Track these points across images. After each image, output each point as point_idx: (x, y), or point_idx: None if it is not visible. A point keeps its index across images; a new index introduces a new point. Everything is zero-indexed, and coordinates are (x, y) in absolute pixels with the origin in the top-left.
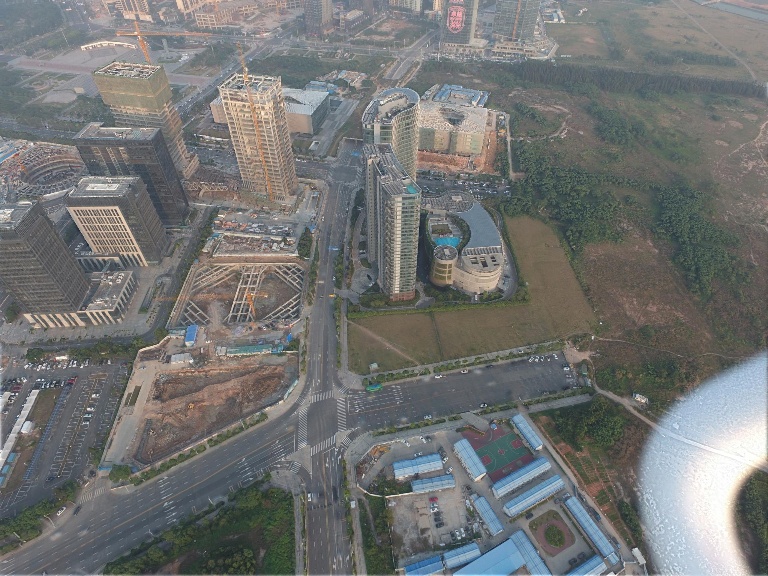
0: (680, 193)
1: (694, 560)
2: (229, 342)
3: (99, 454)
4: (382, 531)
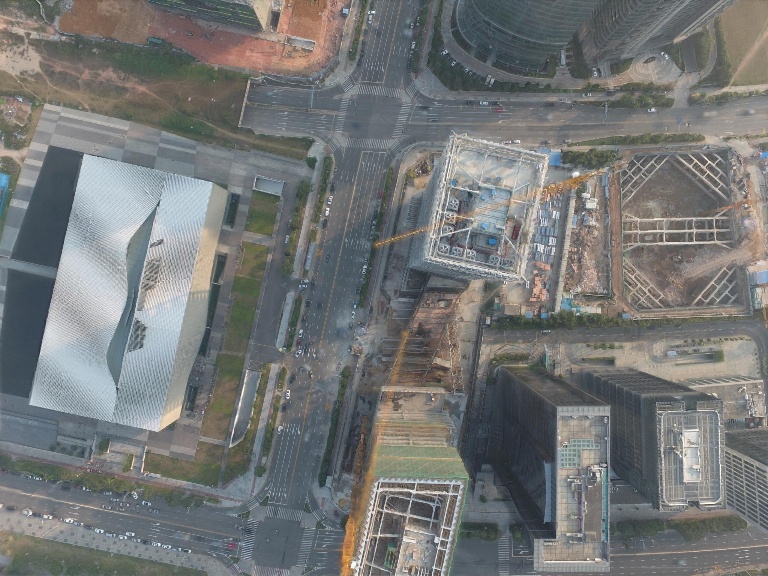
0: None
1: None
2: (767, 230)
3: None
4: None
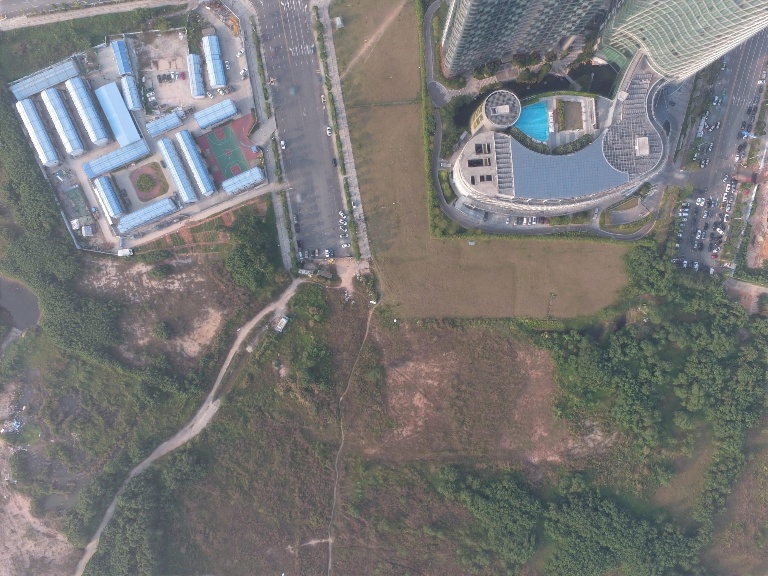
0: (679, 569)
1: (119, 300)
2: None
3: None
4: (155, 23)
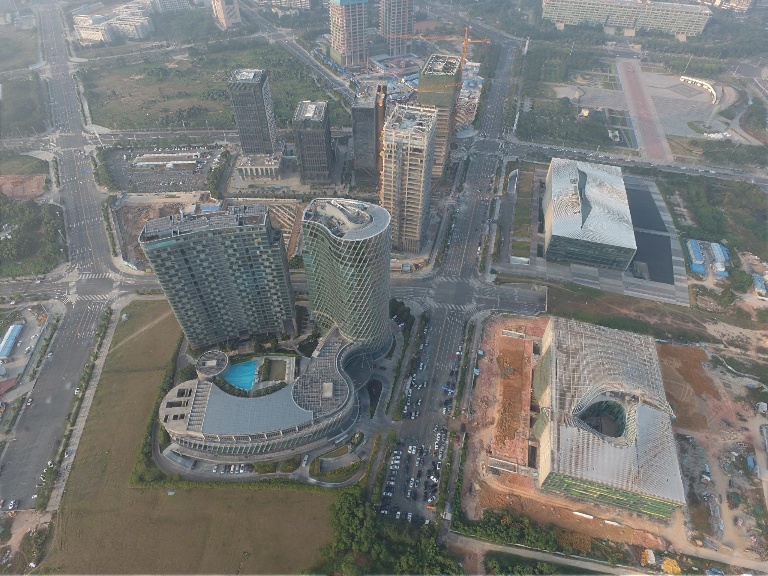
0: None
1: None
2: None
3: (131, 191)
4: None
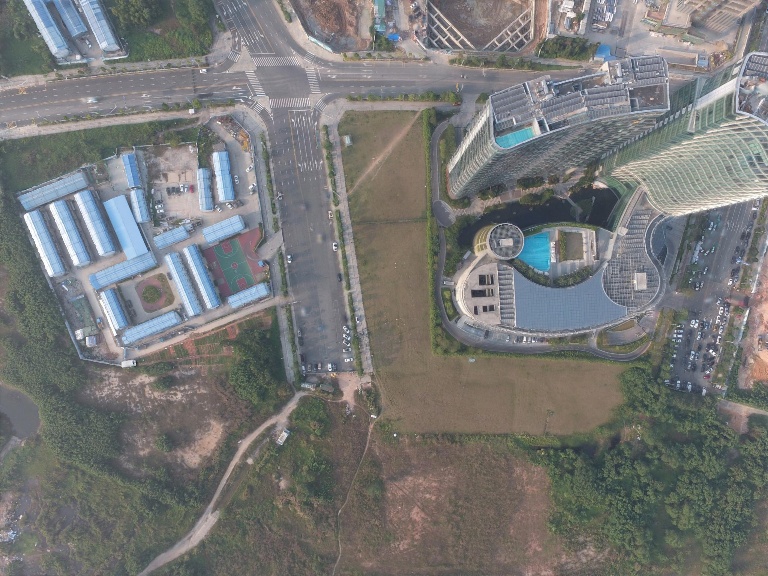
0: None
1: (121, 411)
2: None
3: None
4: (166, 137)
